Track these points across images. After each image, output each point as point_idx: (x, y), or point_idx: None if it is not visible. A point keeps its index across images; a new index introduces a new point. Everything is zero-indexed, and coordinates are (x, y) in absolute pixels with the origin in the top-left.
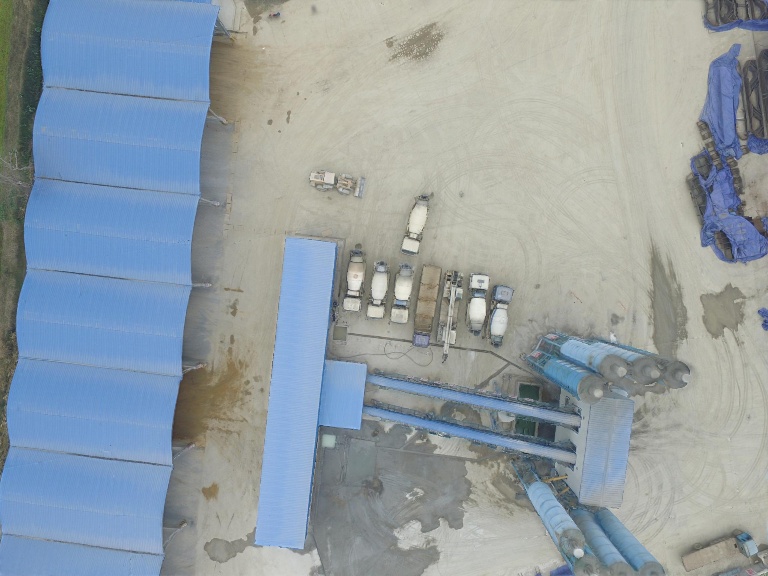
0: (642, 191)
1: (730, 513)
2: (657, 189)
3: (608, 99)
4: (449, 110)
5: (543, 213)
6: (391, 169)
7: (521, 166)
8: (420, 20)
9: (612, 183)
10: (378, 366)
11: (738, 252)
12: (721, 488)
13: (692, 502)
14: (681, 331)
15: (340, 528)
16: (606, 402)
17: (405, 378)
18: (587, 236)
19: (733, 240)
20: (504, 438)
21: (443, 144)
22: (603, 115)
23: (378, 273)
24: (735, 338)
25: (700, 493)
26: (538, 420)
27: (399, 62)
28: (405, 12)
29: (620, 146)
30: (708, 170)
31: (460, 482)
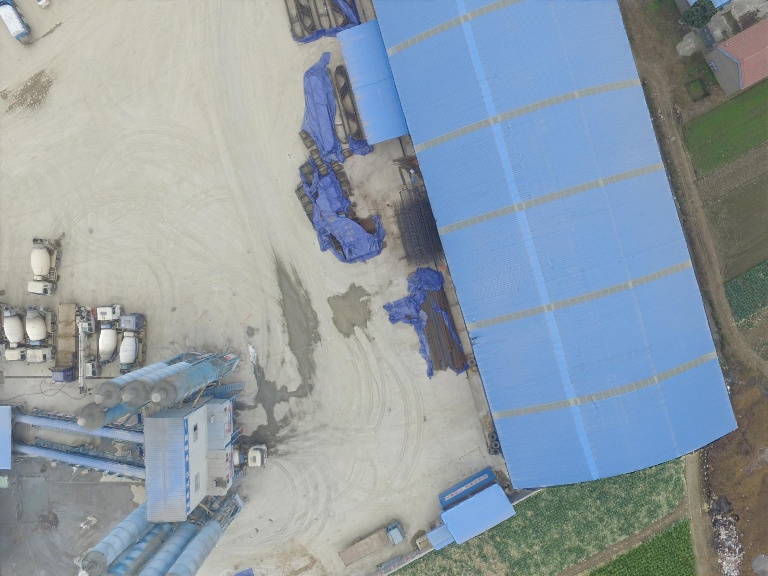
0: (258, 205)
1: (385, 504)
2: (272, 201)
3: (214, 121)
4: (68, 152)
5: (169, 238)
6: (22, 215)
7: (142, 196)
8: (29, 69)
9: (229, 201)
10: (37, 405)
11: (350, 253)
12: (373, 481)
13: (348, 498)
14: (314, 335)
15: (24, 564)
16: (157, 422)
17: (47, 415)
18: (213, 255)
19: (342, 242)
20: (113, 464)
21: (67, 185)
22: (211, 137)
23: (4, 318)
24: (366, 335)
25: (354, 488)
26: (137, 443)
27: (15, 112)
28: (14, 64)
29: (231, 165)
30: (312, 177)
31: (129, 506)
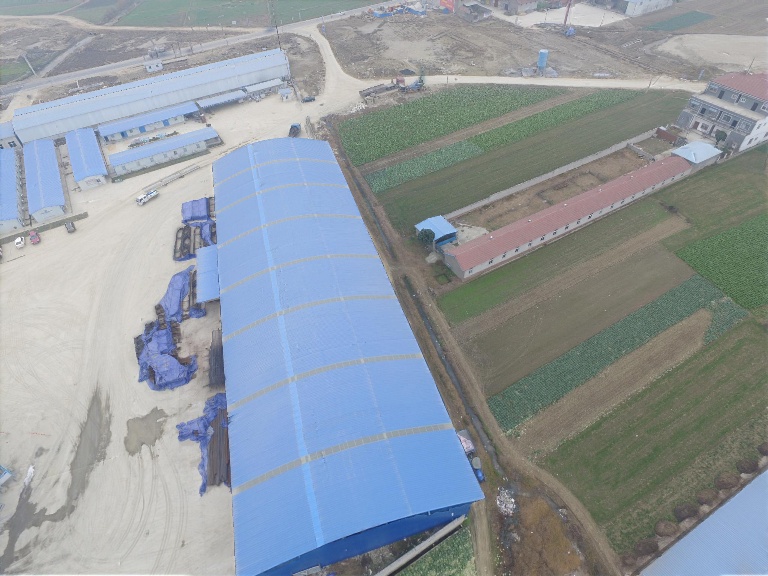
0: (101, 351)
1: None
2: (114, 348)
3: (96, 301)
4: None
5: (13, 376)
6: None
7: (11, 347)
8: None
9: (79, 349)
10: None
11: (161, 380)
12: None
13: None
14: (101, 454)
15: None
16: None
17: None
18: (43, 387)
19: (157, 371)
20: None
21: None
22: (89, 310)
23: None
24: (151, 453)
25: None
26: None
27: None
28: None
29: (94, 326)
30: None
31: None
